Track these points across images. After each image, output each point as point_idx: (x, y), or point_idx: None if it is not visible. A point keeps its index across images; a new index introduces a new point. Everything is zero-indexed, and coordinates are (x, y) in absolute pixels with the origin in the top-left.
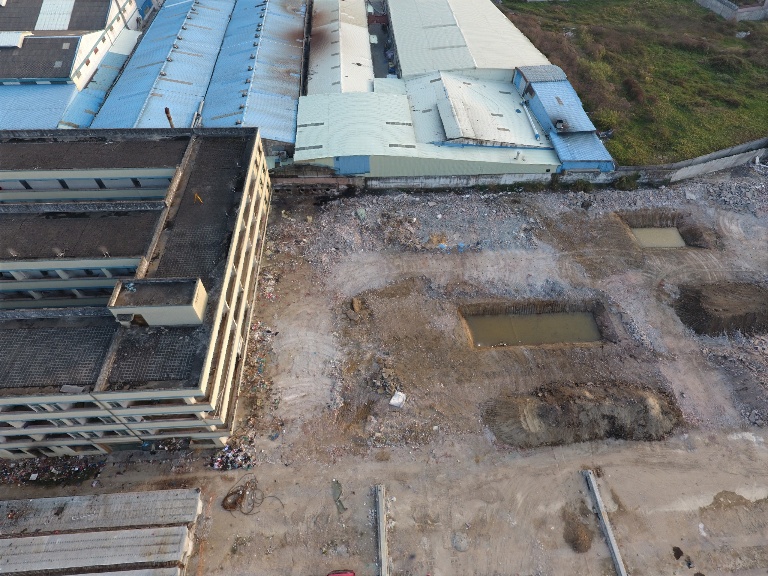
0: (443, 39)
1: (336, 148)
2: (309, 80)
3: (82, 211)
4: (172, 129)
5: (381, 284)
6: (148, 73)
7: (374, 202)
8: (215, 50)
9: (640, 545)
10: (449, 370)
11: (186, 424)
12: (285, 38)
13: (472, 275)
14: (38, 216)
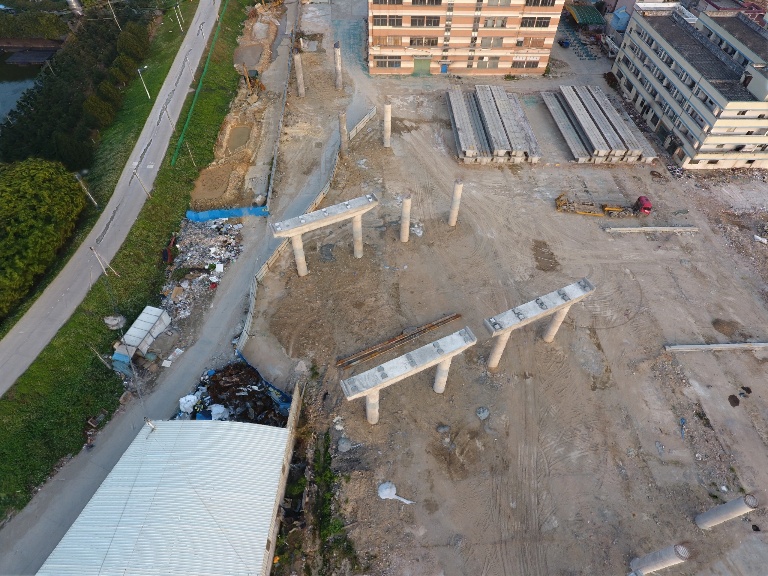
0: None
1: None
2: None
3: None
4: None
5: None
6: None
7: None
8: None
9: (739, 365)
10: None
11: (694, 131)
12: None
13: None
14: None
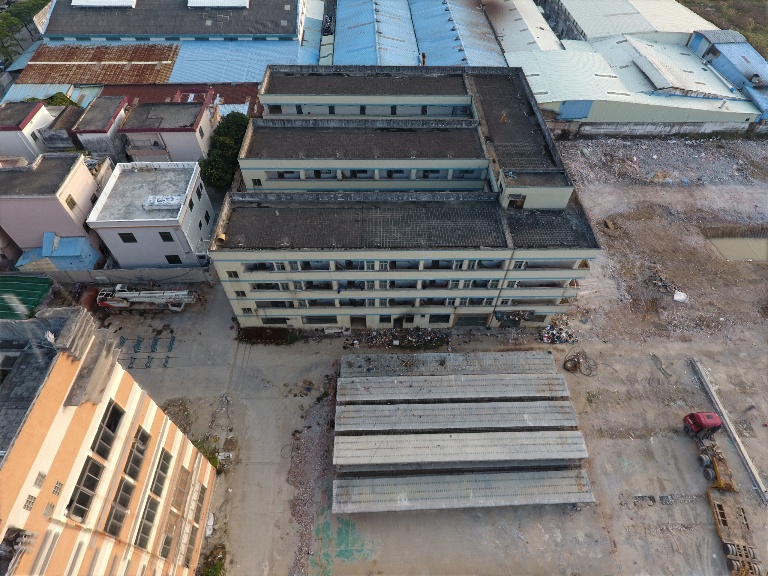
0: (614, 7)
1: (562, 94)
2: (501, 41)
3: (408, 127)
4: (447, 67)
5: (625, 209)
6: (364, 31)
7: (590, 145)
8: (407, 15)
9: None
10: (714, 277)
11: (546, 294)
12: (467, 5)
13: (704, 204)
14: (374, 130)
